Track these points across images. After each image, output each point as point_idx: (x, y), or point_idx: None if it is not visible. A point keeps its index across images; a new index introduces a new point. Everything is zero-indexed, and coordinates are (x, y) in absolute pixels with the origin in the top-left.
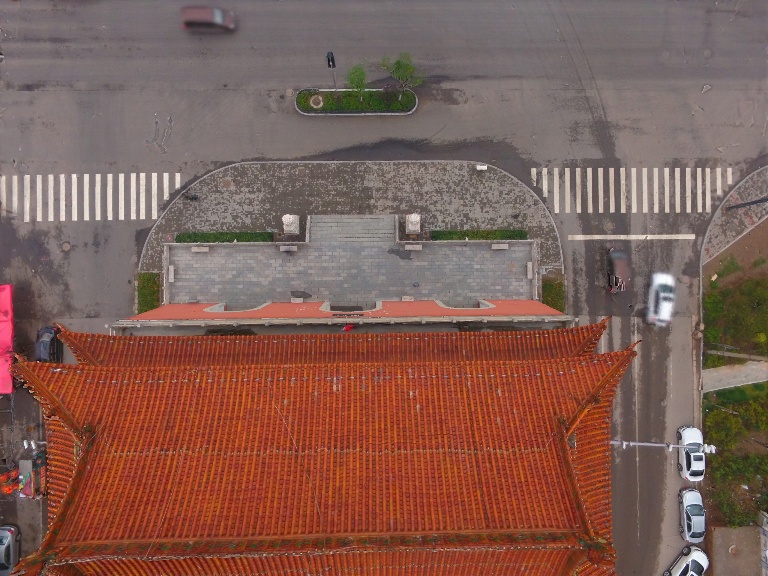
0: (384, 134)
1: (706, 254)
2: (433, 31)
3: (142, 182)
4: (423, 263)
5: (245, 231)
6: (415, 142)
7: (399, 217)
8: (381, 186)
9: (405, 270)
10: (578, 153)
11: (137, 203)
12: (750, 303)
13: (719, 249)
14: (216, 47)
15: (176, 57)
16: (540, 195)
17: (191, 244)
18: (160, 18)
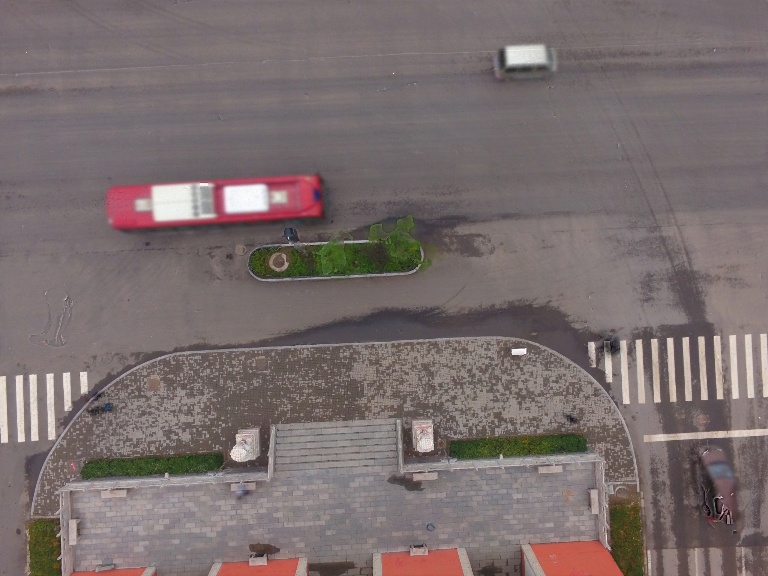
0: (377, 303)
1: None
2: (442, 153)
3: (32, 387)
4: (439, 495)
5: (182, 452)
6: (421, 312)
7: (402, 422)
8: (375, 378)
9: (414, 506)
10: (653, 318)
11: (26, 418)
12: None
13: None
14: (132, 189)
15: (75, 206)
16: (602, 380)
17: (101, 486)
18: (50, 151)
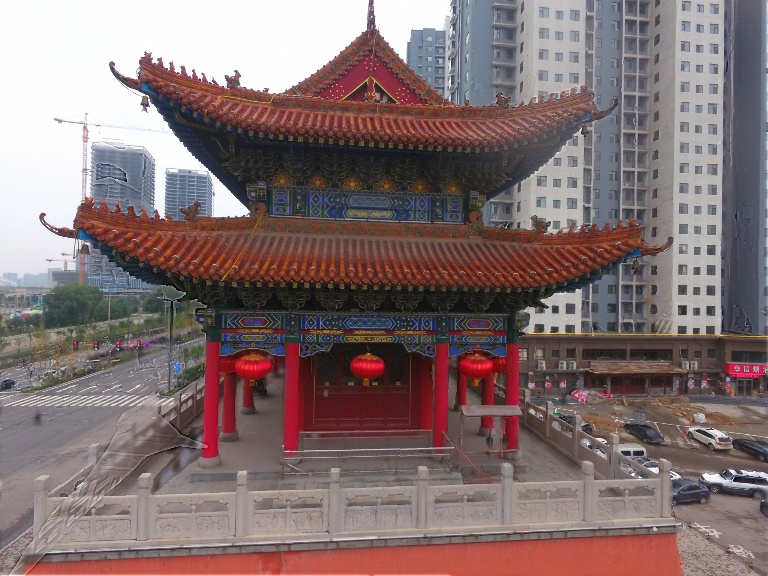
0: None
1: None
2: None
3: None
4: None
5: None
6: None
7: None
8: None
9: None
10: None
11: None
12: None
13: None
14: None
15: None
16: None
17: None
18: None
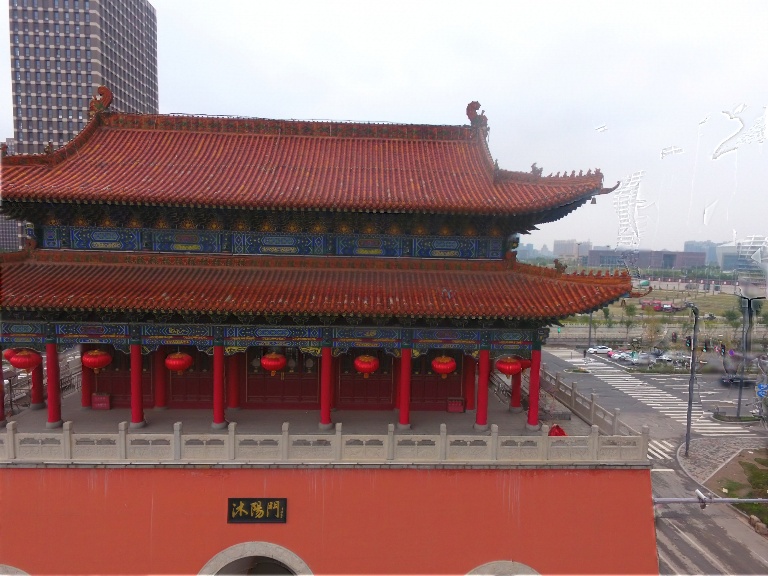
0: None
1: (697, 478)
2: None
3: None
4: None
5: None
6: None
7: None
8: None
9: None
10: None
11: None
12: (765, 472)
13: (707, 475)
14: None
15: None
16: None
17: None
18: None
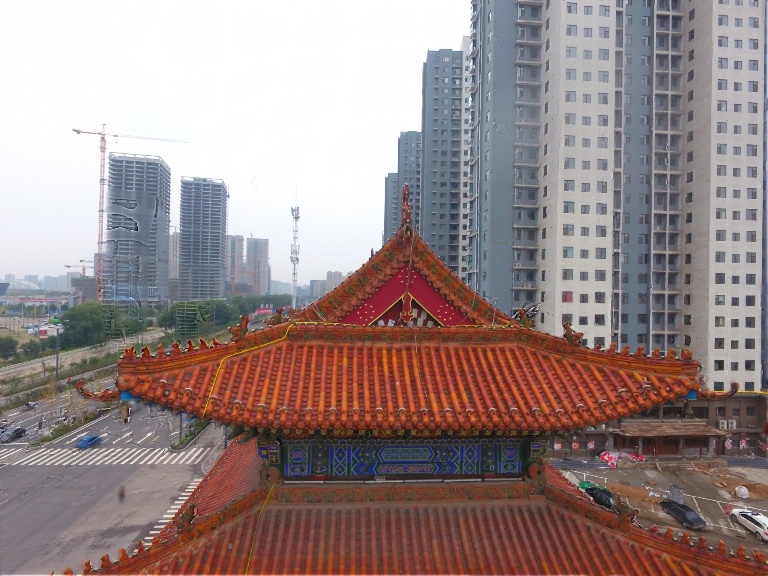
0: None
1: None
2: None
3: None
4: None
5: None
6: None
7: None
8: None
9: None
10: (124, 544)
11: None
12: None
13: None
14: None
15: None
16: None
17: None
18: None
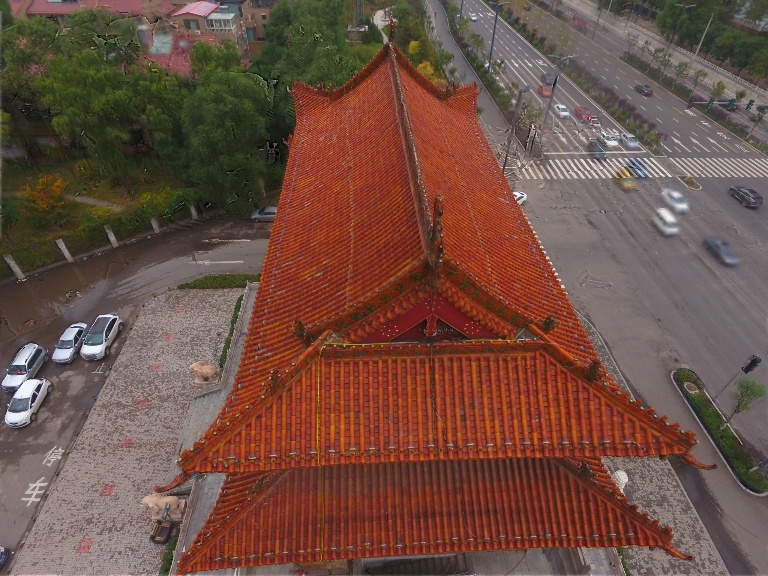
0: (698, 458)
1: None
2: None
3: None
4: None
5: None
6: (710, 495)
7: None
8: None
9: None
10: None
11: None
12: None
13: None
14: (689, 313)
15: (662, 290)
16: None
17: None
18: (687, 281)
